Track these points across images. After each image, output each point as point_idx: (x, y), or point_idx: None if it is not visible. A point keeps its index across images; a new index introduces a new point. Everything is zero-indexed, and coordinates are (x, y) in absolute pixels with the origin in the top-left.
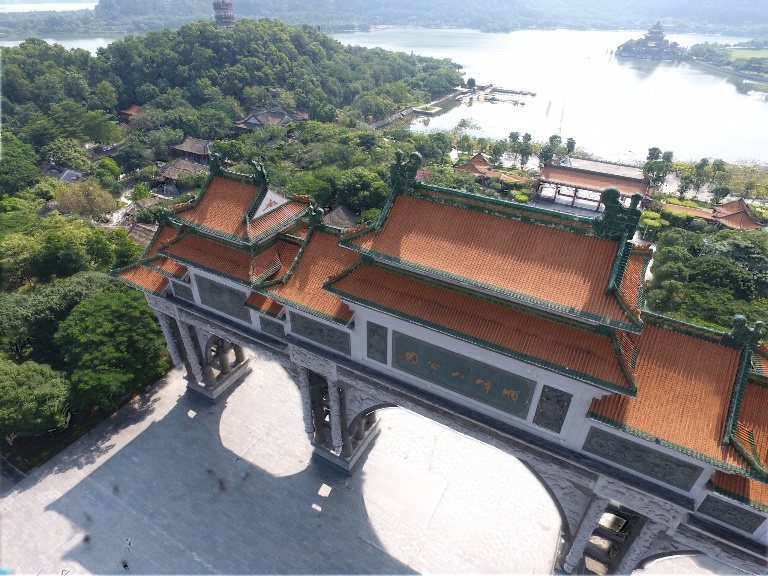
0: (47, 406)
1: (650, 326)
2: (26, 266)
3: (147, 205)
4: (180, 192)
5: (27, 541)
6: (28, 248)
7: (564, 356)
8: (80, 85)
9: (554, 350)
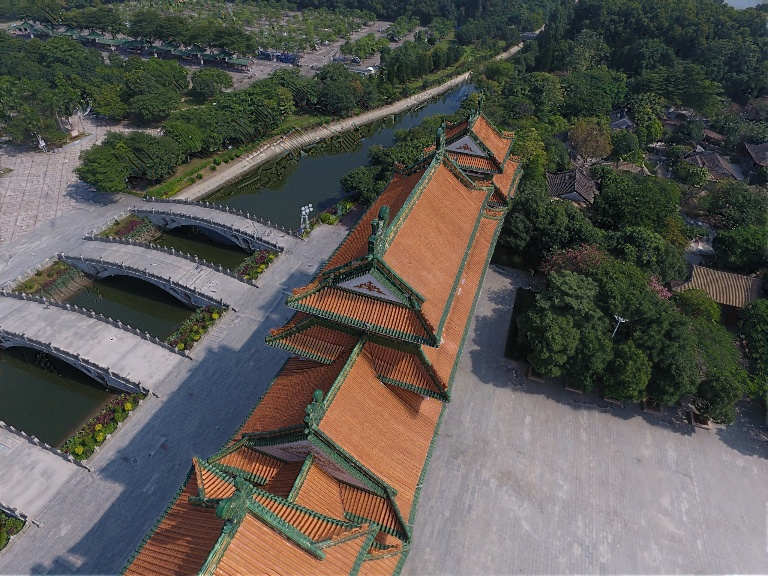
0: None
1: None
2: None
3: (623, 168)
4: (671, 177)
5: (326, 247)
6: None
7: None
8: (747, 57)
9: None
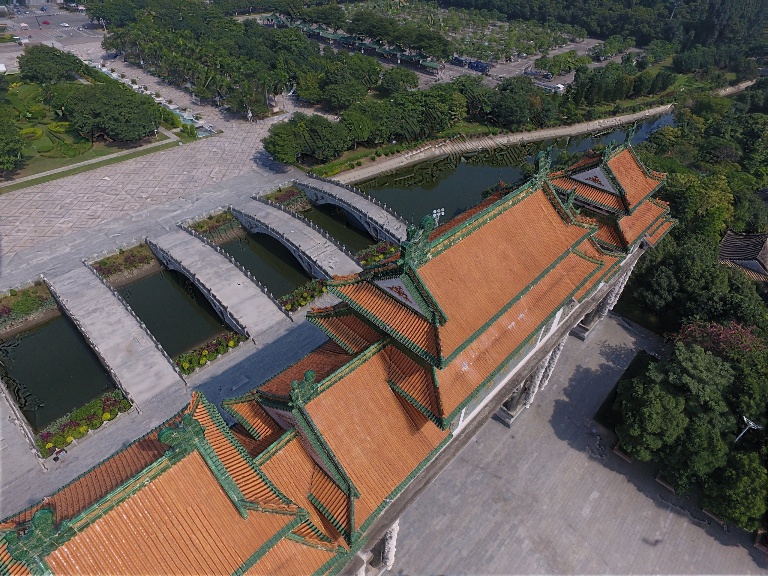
0: None
1: None
2: (665, 195)
3: None
4: None
5: None
6: (673, 183)
7: None
8: None
9: None
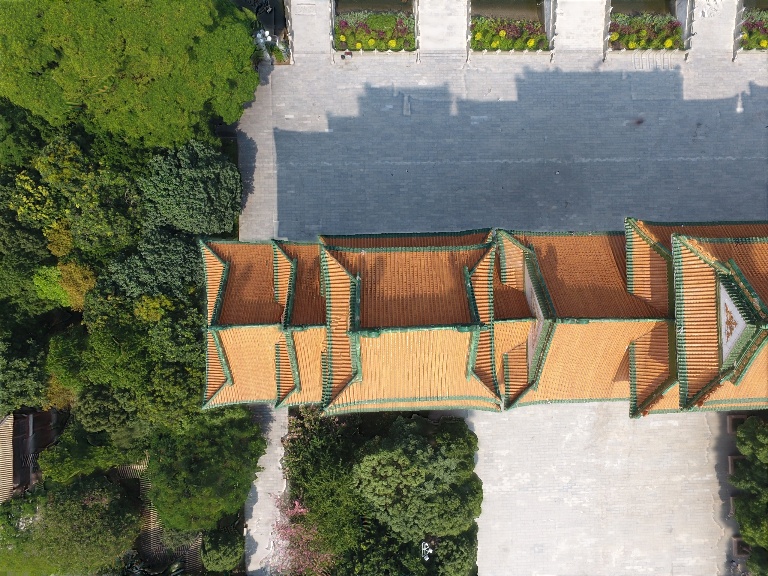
0: None
1: (635, 316)
2: None
3: None
4: None
5: None
6: None
7: (693, 234)
8: None
9: (704, 236)
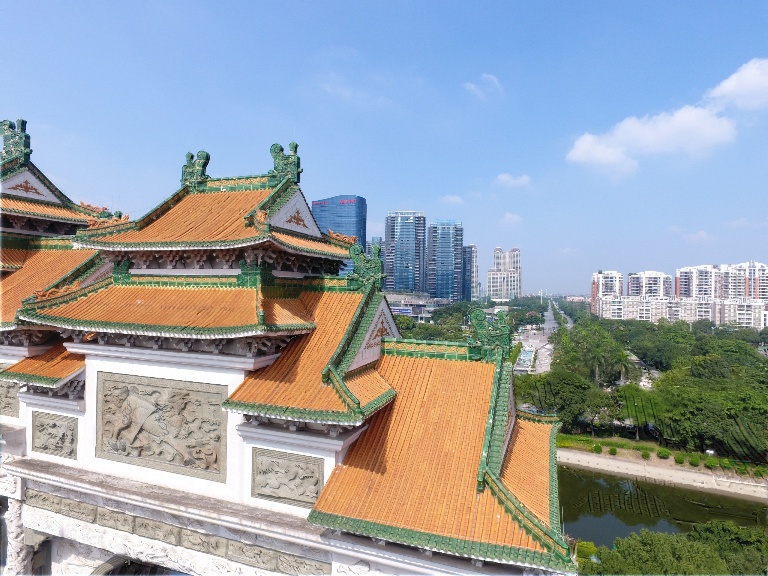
0: (588, 562)
1: None
2: None
3: None
4: None
5: None
6: None
7: None
8: None
9: None
